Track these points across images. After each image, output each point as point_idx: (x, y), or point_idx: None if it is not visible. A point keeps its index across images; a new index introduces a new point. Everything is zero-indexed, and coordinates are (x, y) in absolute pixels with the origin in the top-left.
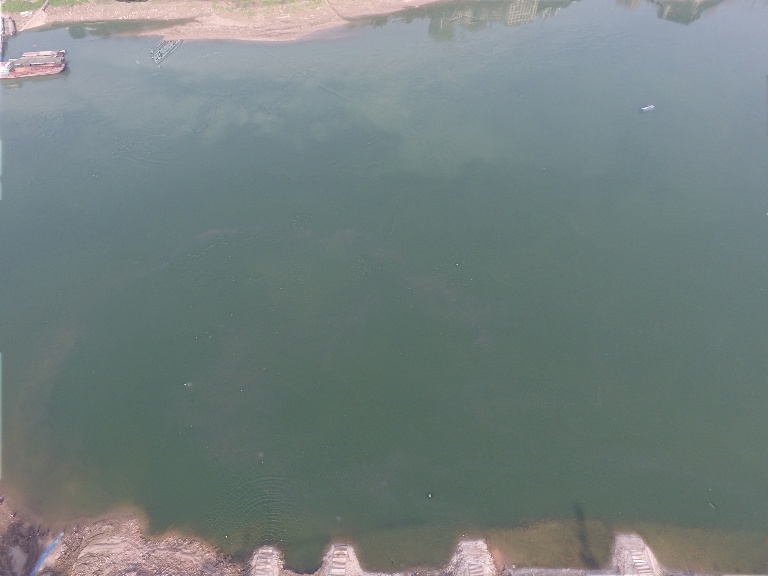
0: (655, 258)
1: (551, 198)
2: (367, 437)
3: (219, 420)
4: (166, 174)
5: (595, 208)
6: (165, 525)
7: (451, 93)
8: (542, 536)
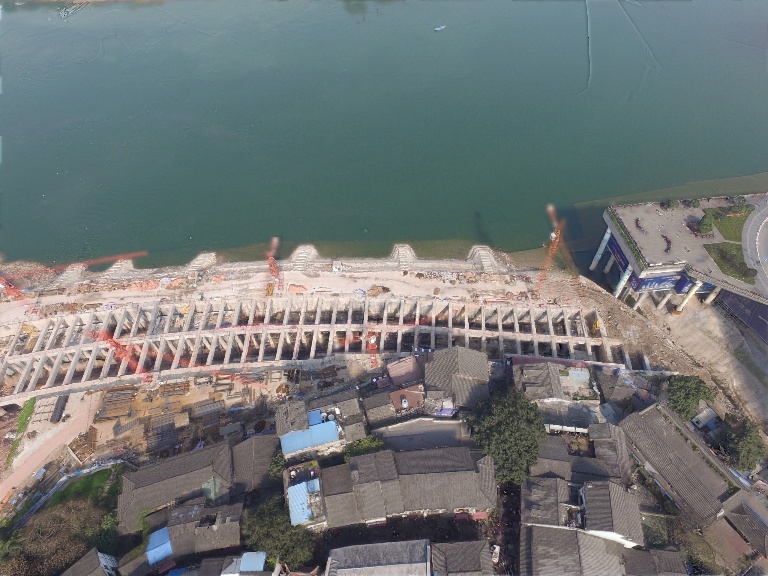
0: (400, 116)
1: (341, 87)
2: (159, 214)
3: (62, 211)
4: (55, 86)
5: (370, 90)
6: (16, 259)
7: (296, 28)
8: (253, 249)
